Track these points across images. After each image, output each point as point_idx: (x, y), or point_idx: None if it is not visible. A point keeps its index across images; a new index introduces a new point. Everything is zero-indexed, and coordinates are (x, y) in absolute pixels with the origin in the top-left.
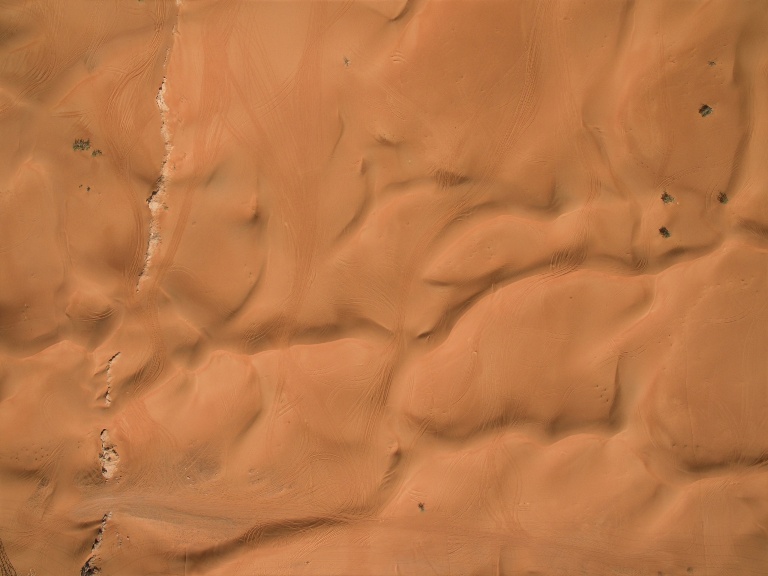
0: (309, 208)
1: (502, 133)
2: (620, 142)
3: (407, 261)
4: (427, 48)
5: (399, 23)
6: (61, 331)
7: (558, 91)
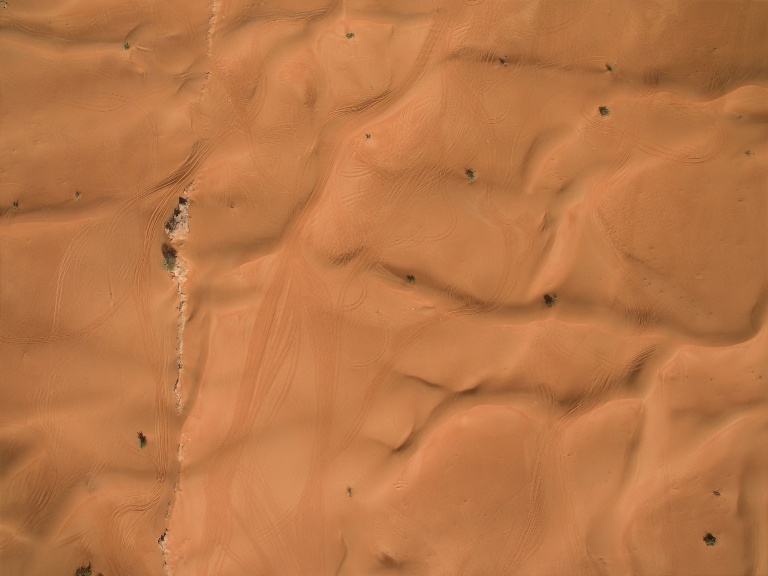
0: None
1: (506, 558)
2: (624, 568)
3: None
4: (430, 474)
5: (402, 456)
6: None
7: (562, 524)
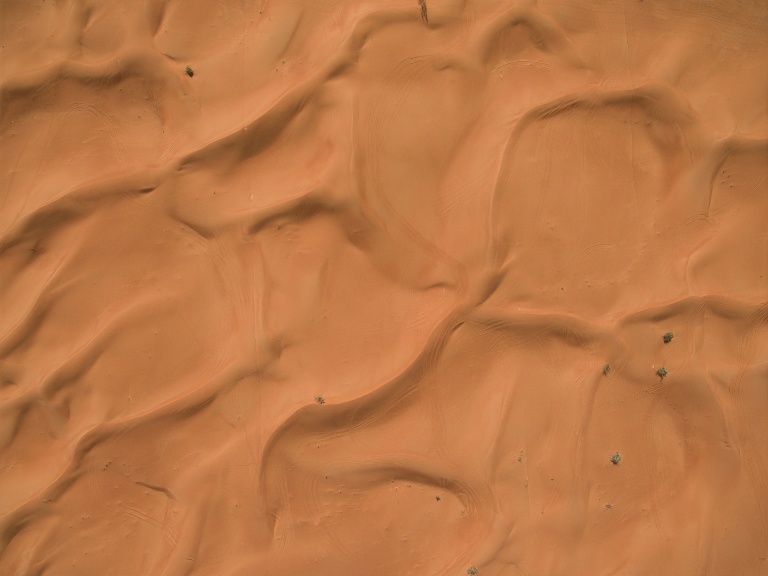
0: None
1: None
2: (700, 431)
3: None
4: None
5: None
6: None
7: None
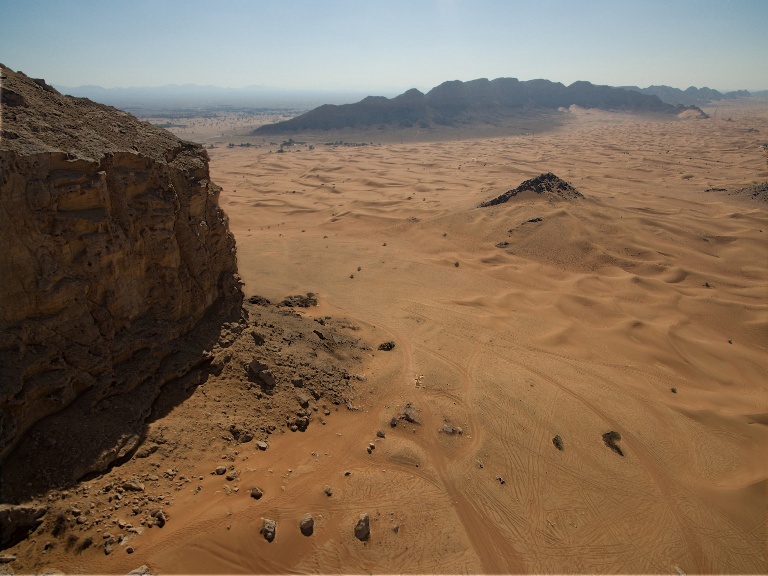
0: None
1: None
2: None
3: (713, 154)
4: None
5: None
6: None
7: None
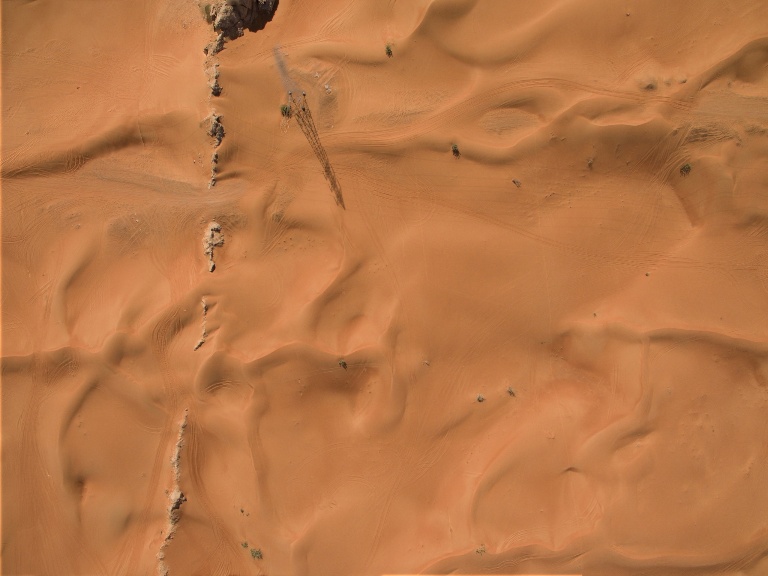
0: (30, 491)
1: None
2: None
3: None
4: None
5: None
6: (256, 371)
7: None
